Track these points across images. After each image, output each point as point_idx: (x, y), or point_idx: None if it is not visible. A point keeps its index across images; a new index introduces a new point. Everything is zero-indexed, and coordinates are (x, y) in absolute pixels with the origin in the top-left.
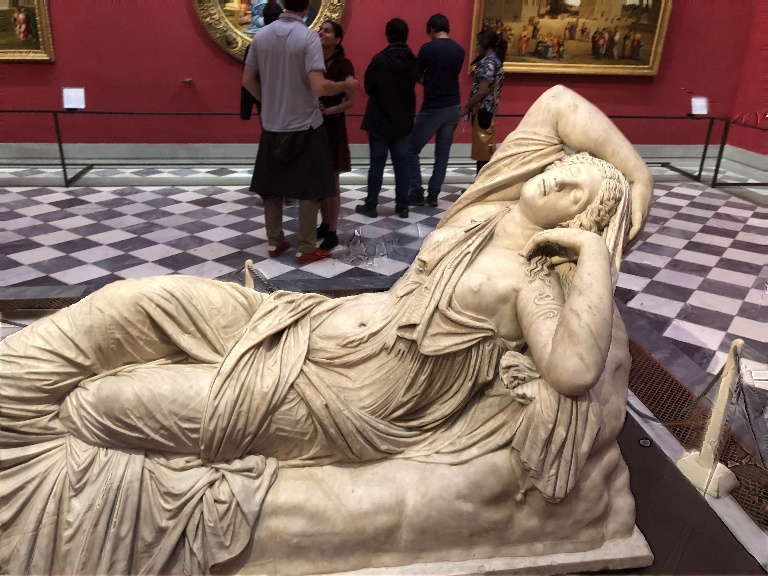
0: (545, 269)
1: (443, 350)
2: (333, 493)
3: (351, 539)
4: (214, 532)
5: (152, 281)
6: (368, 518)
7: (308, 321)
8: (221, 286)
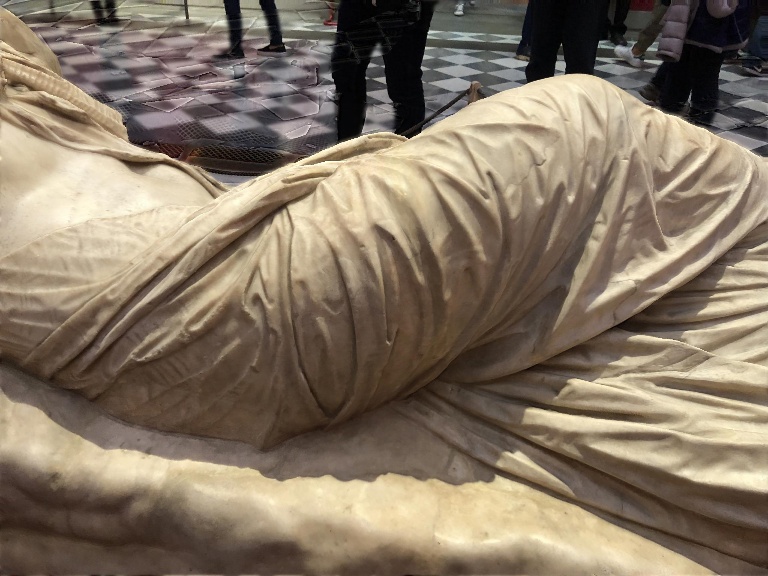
0: None
1: None
2: None
3: None
4: None
5: (533, 85)
6: None
7: None
8: (404, 147)
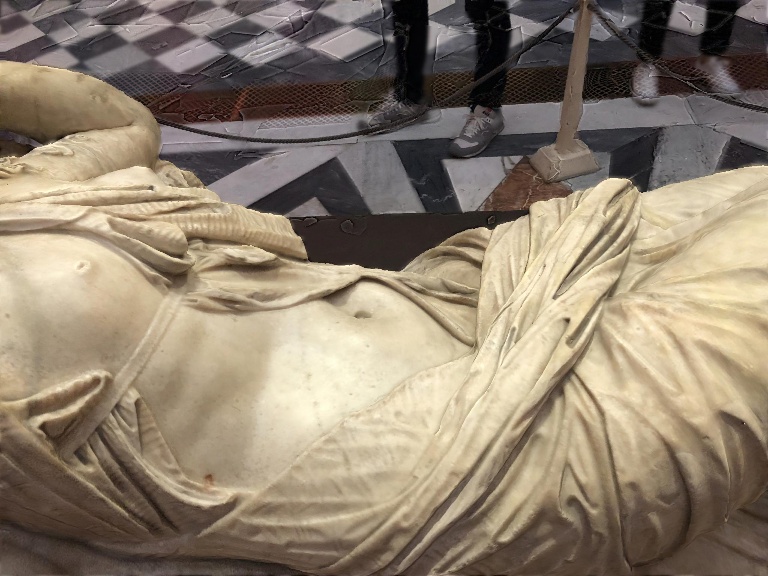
0: None
1: None
2: None
3: None
4: None
5: None
6: None
7: (481, 325)
8: (717, 283)
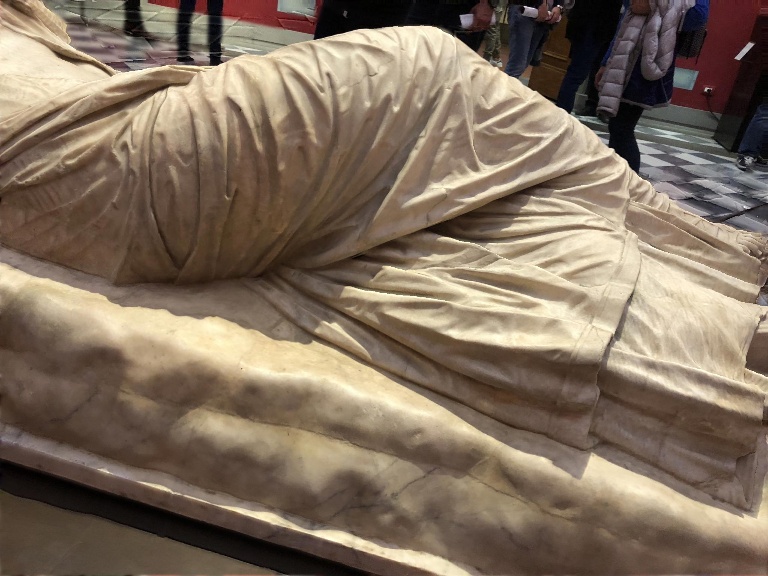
0: None
1: None
2: None
3: None
4: None
5: None
6: None
7: None
8: (271, 54)
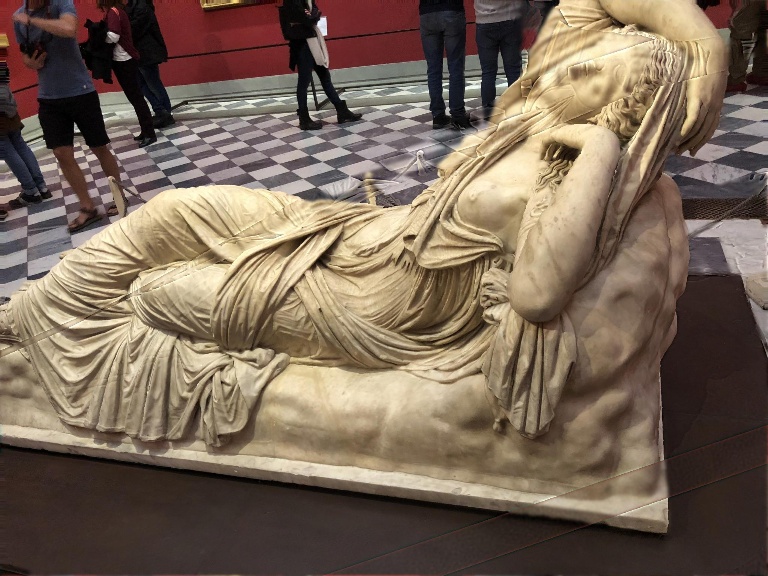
0: (560, 175)
1: (441, 264)
2: (324, 392)
3: (334, 436)
4: (218, 408)
5: (194, 190)
6: (350, 420)
7: (338, 230)
8: (264, 195)
